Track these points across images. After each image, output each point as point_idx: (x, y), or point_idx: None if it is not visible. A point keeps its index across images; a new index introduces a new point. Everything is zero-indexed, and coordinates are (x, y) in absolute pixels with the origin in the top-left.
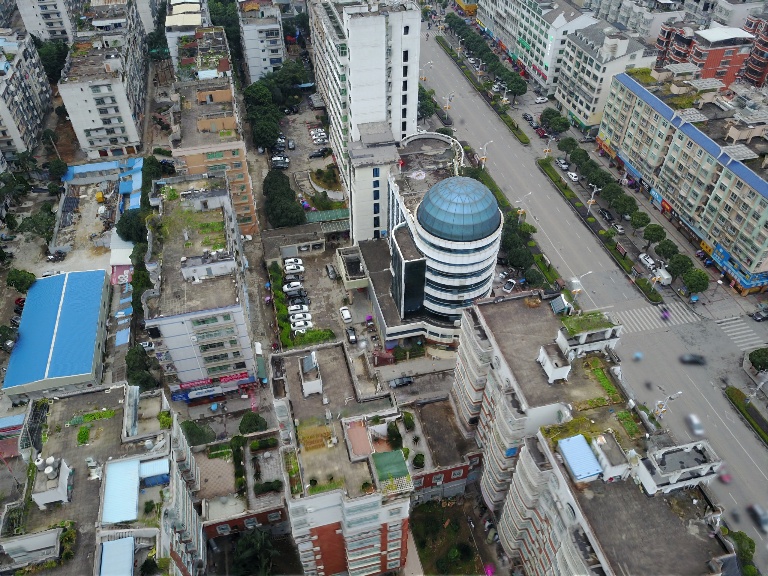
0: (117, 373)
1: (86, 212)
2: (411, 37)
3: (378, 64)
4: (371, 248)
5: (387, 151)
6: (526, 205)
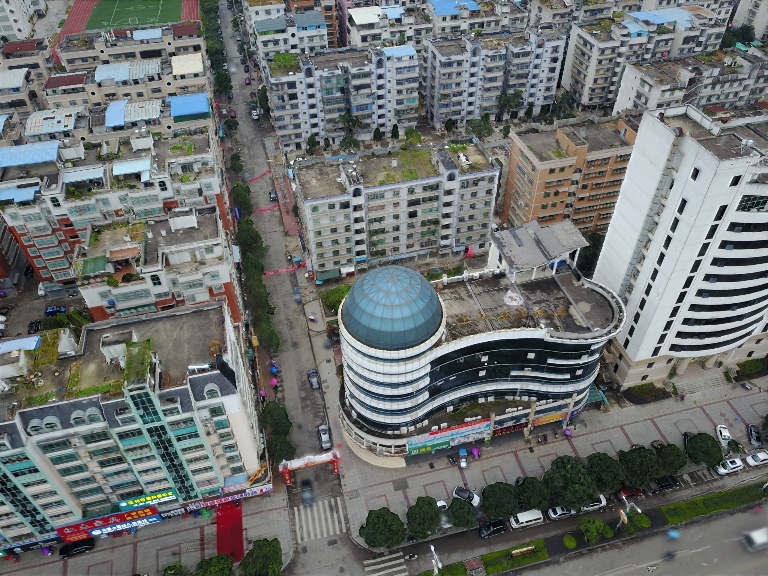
0: None
1: None
2: (697, 188)
3: (647, 187)
4: None
5: (533, 256)
6: (683, 552)
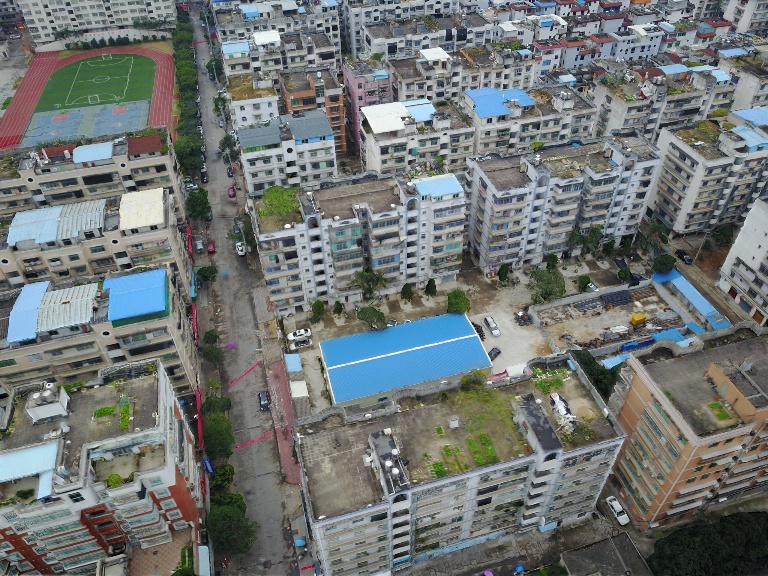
0: None
1: (610, 317)
2: None
3: None
4: None
5: None
6: None
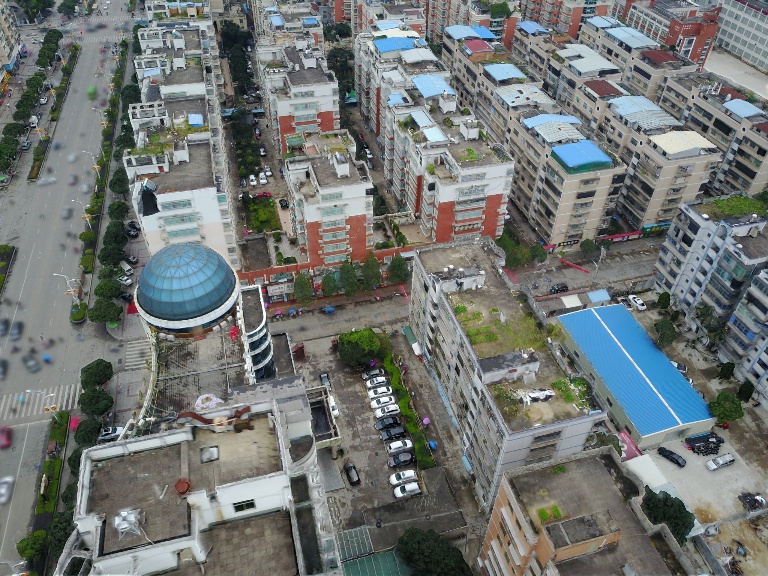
0: None
1: None
2: None
3: None
4: None
5: None
6: None
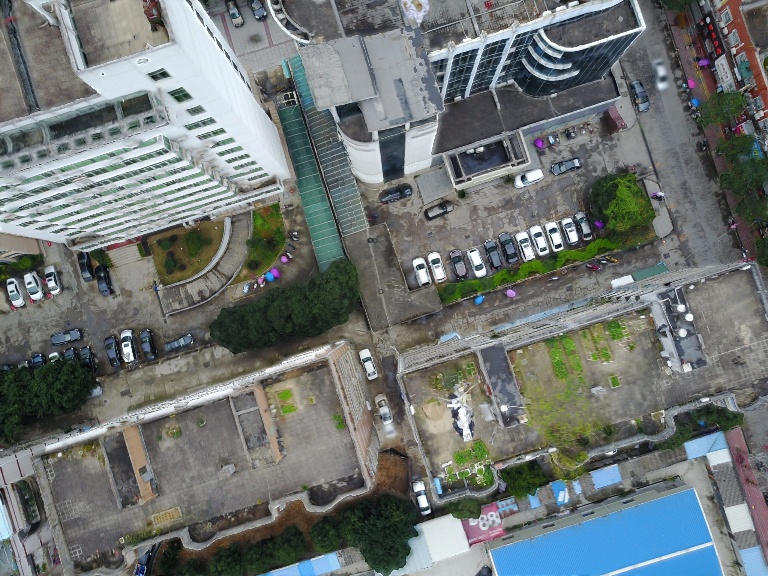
0: (669, 460)
1: None
2: None
3: (199, 30)
4: (445, 134)
5: (383, 53)
6: None
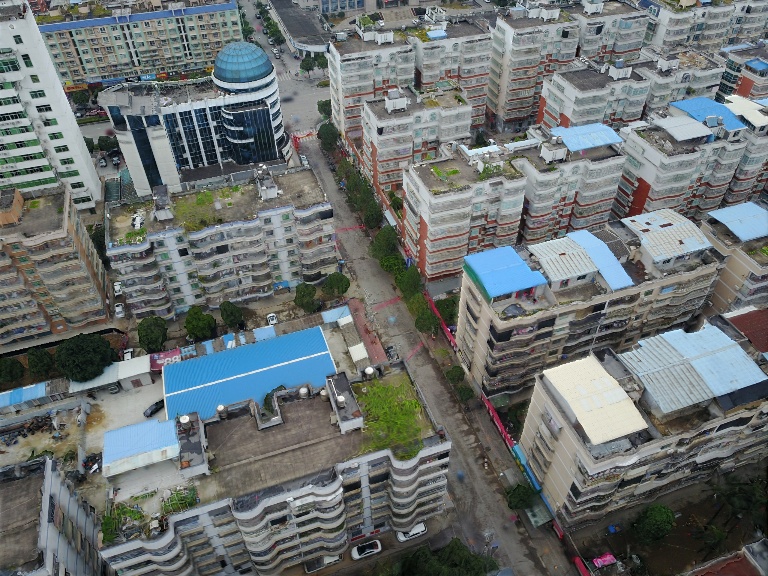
0: (310, 323)
1: None
2: None
3: (47, 57)
4: (190, 177)
5: (139, 100)
6: None
